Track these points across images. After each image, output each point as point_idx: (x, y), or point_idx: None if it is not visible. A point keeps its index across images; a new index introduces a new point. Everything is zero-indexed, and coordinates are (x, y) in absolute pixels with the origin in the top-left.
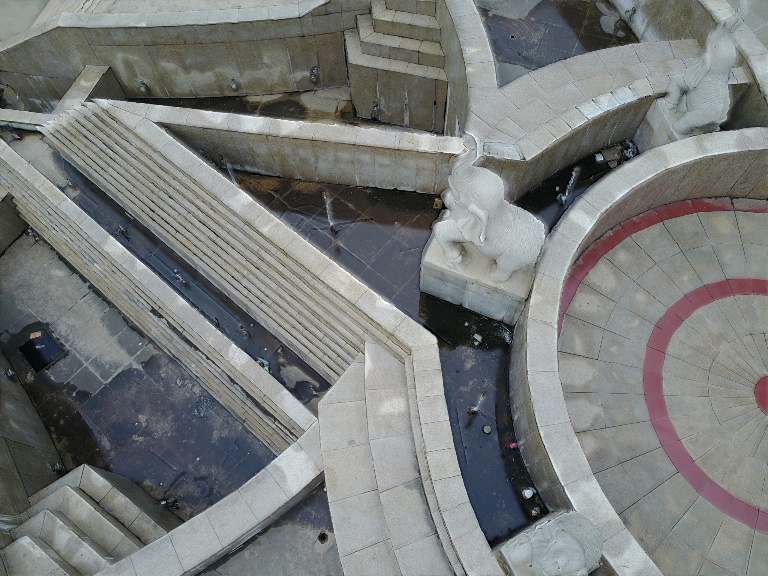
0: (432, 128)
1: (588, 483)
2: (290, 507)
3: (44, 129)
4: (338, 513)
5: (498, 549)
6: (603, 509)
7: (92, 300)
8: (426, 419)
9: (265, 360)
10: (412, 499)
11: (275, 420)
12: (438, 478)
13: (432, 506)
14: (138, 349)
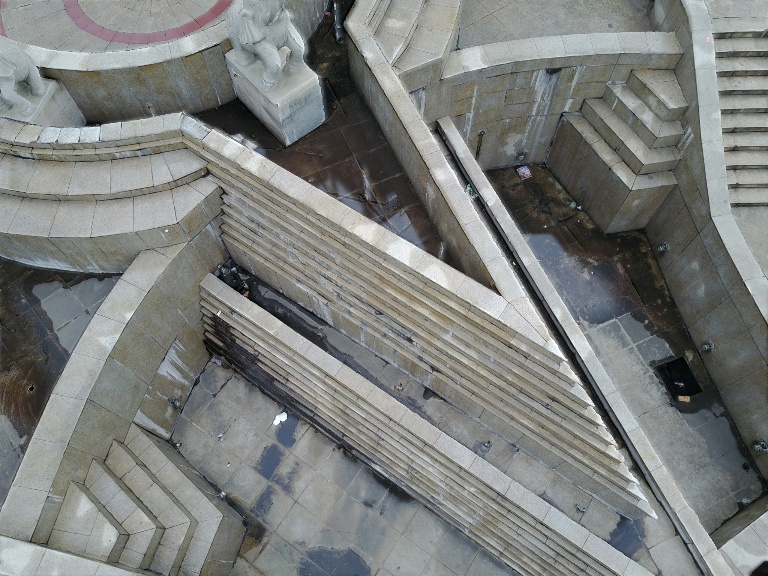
0: (176, 452)
1: None
2: None
3: (646, 507)
4: (455, 2)
5: None
6: None
7: None
8: None
9: None
10: None
11: None
12: None
13: None
14: None
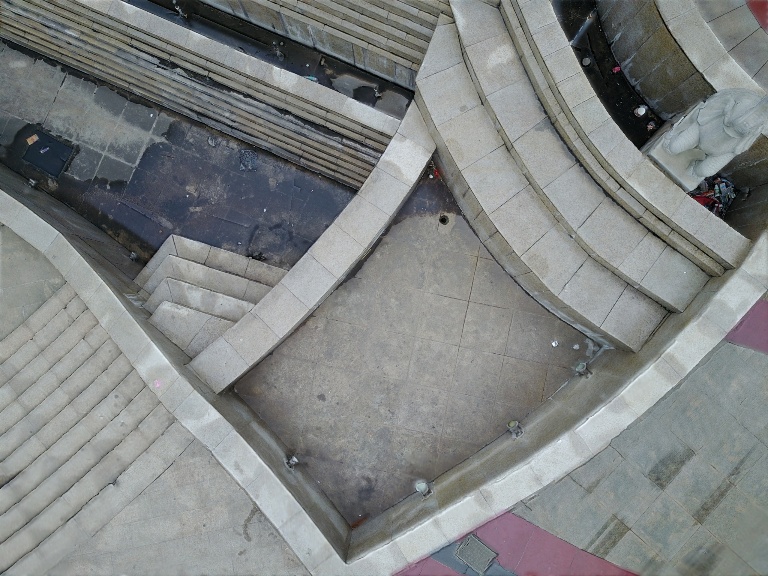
0: None
1: (725, 63)
2: (404, 201)
3: None
4: (473, 177)
5: (646, 154)
6: (743, 83)
7: (74, 84)
8: (546, 51)
9: (312, 76)
10: (545, 139)
11: (342, 138)
12: (575, 104)
13: (572, 136)
14: (152, 122)
